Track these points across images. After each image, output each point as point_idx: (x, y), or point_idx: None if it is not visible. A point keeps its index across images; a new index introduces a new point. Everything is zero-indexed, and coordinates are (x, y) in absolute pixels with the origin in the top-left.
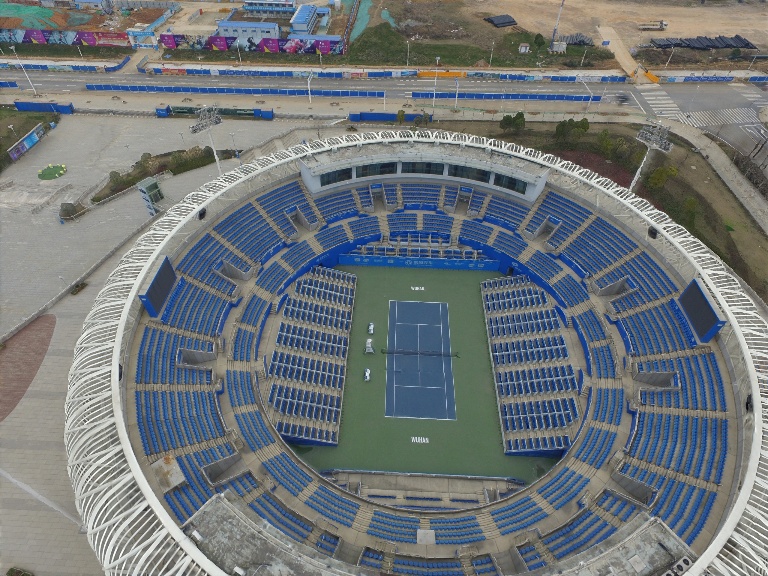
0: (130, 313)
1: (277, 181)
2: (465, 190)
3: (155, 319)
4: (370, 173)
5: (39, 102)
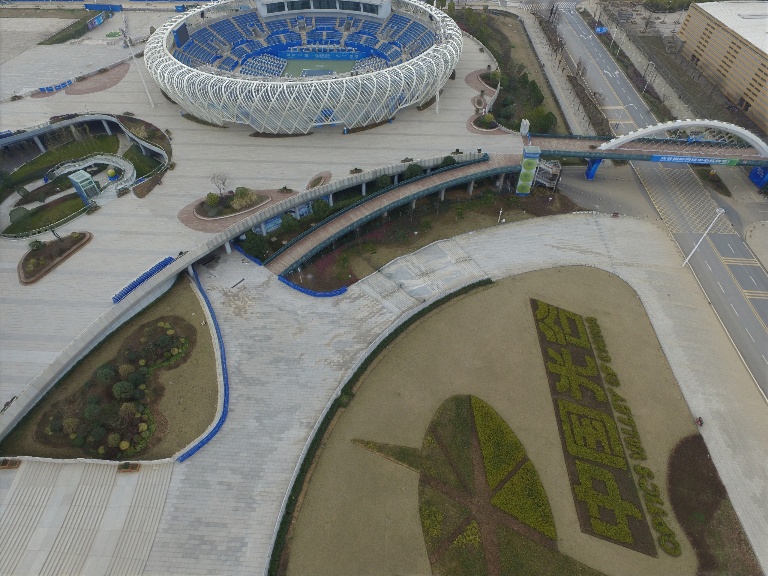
0: (168, 45)
1: (244, 11)
2: (350, 19)
3: (180, 48)
4: (296, 8)
5: (100, 4)
